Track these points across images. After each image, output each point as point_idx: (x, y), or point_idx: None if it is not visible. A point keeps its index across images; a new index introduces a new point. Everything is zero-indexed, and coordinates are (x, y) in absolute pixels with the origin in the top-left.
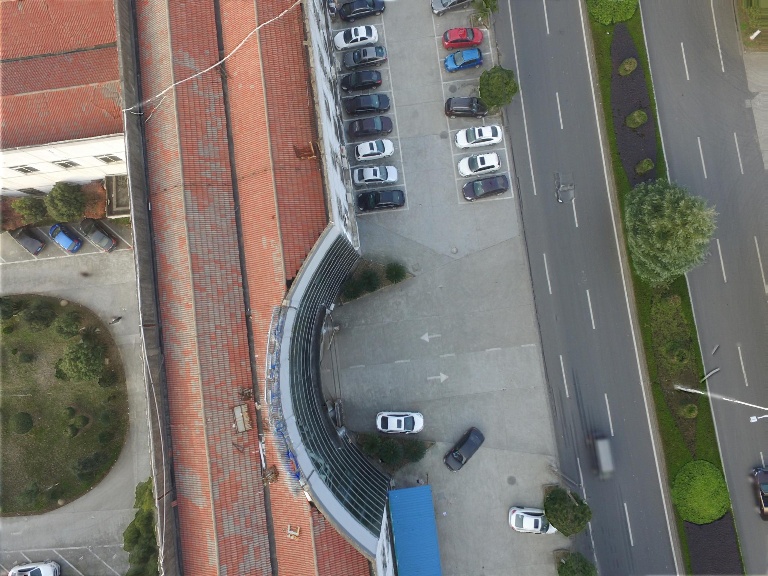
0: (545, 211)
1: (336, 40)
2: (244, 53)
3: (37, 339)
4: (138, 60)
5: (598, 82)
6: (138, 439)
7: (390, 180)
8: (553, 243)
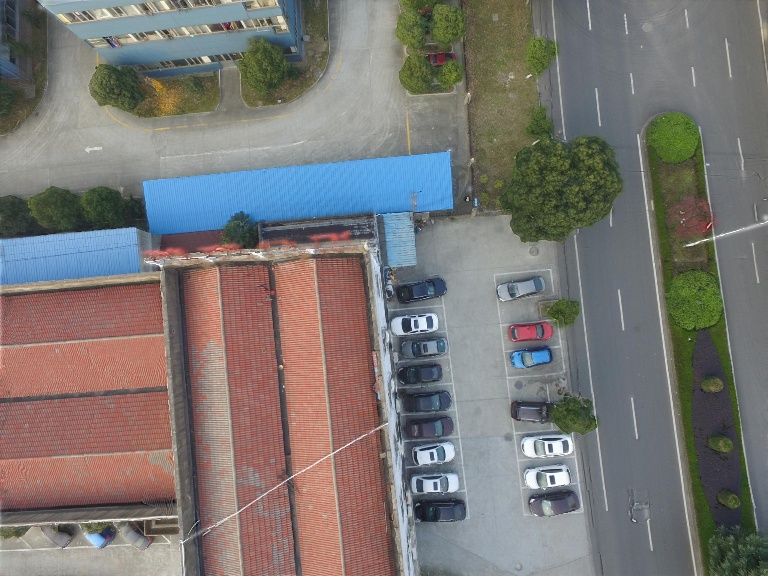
0: (617, 530)
1: (393, 327)
2: (316, 473)
3: None
4: (194, 458)
5: (677, 391)
6: None
7: (451, 492)
8: (626, 567)
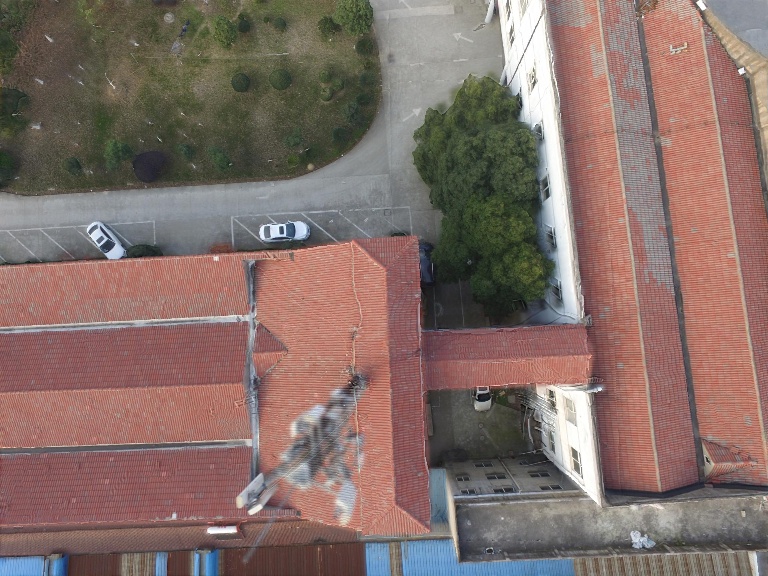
0: None
1: None
2: None
3: (287, 11)
4: None
5: None
6: (392, 109)
7: None
8: None
